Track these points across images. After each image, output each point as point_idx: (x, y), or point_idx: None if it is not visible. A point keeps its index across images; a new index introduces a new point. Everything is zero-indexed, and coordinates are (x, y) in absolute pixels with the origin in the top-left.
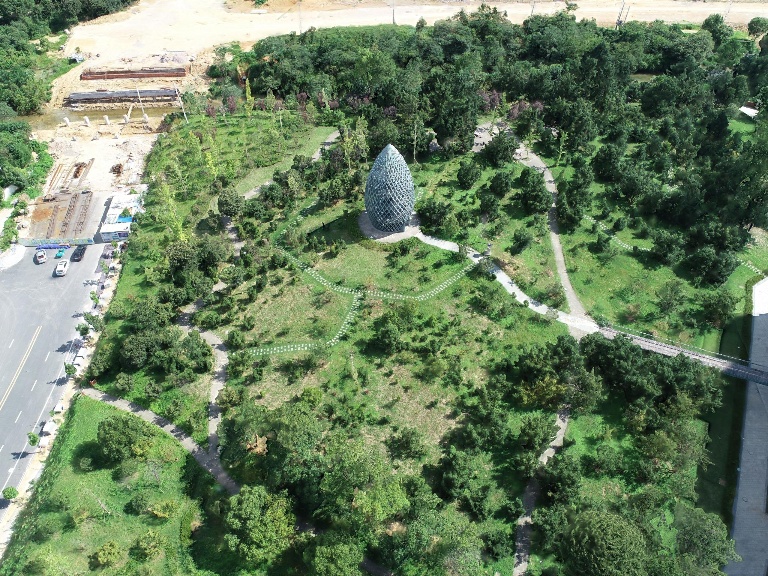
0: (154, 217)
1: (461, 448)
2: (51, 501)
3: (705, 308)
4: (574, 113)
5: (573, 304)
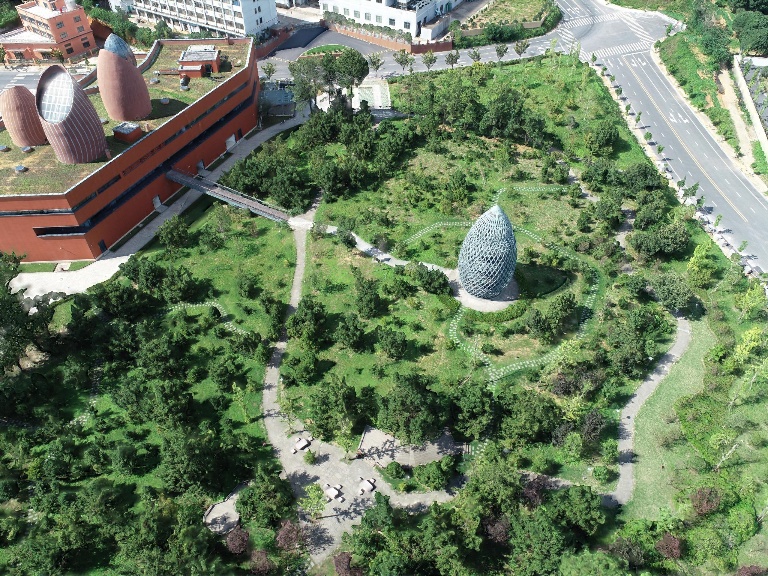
0: (762, 313)
1: (404, 154)
2: (619, 125)
3: (186, 236)
4: (197, 444)
5: (302, 237)
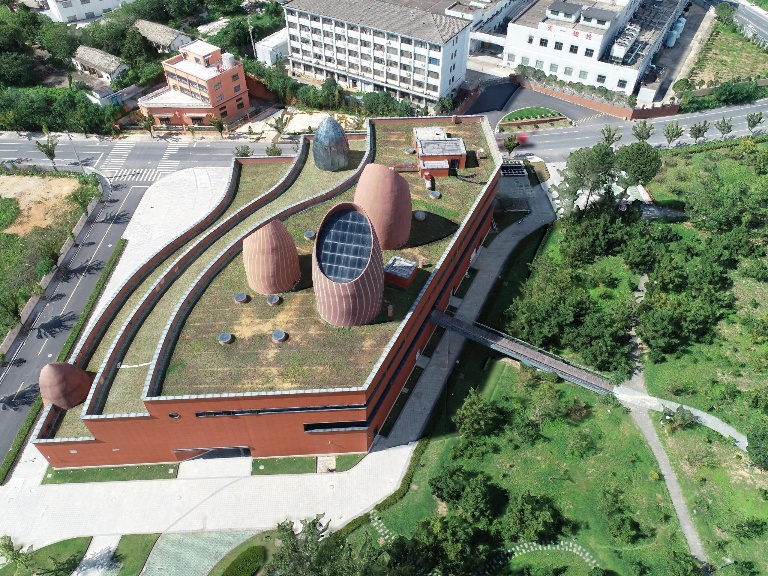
0: None
1: None
2: None
3: None
4: None
5: (647, 423)
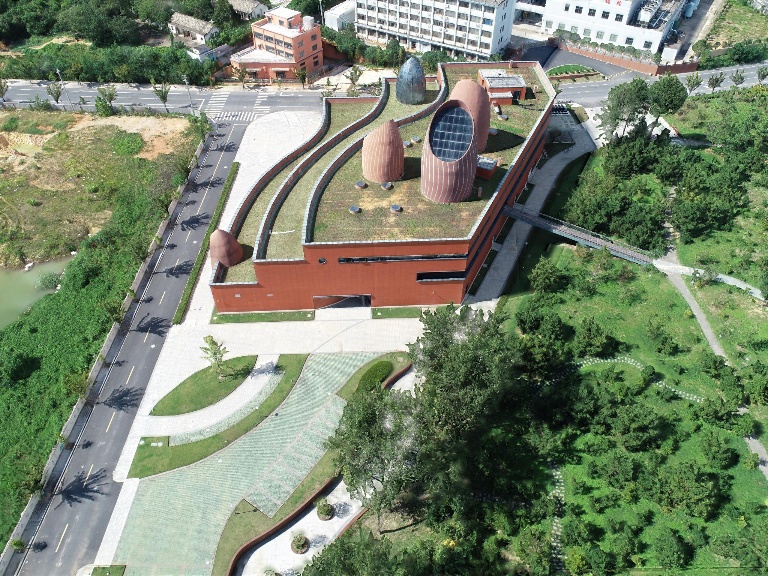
0: None
1: (732, 189)
2: None
3: None
4: None
5: (681, 283)
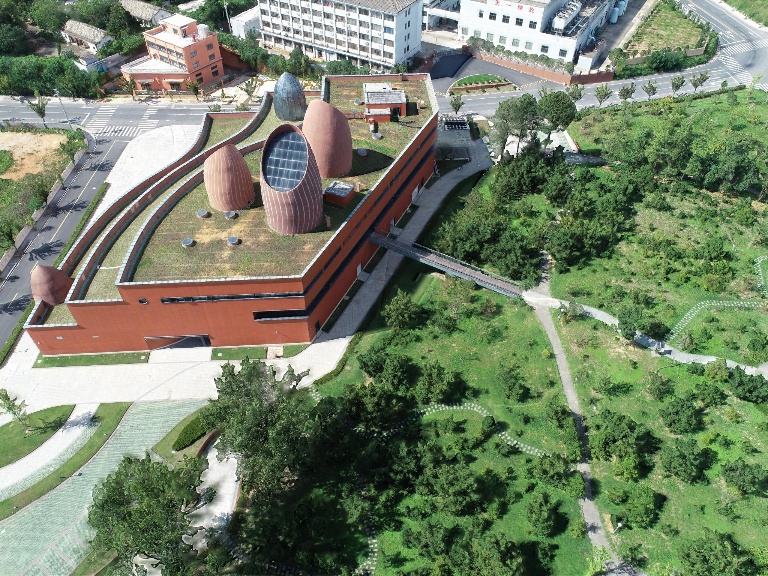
0: None
1: (621, 211)
2: None
3: None
4: None
5: (547, 318)
